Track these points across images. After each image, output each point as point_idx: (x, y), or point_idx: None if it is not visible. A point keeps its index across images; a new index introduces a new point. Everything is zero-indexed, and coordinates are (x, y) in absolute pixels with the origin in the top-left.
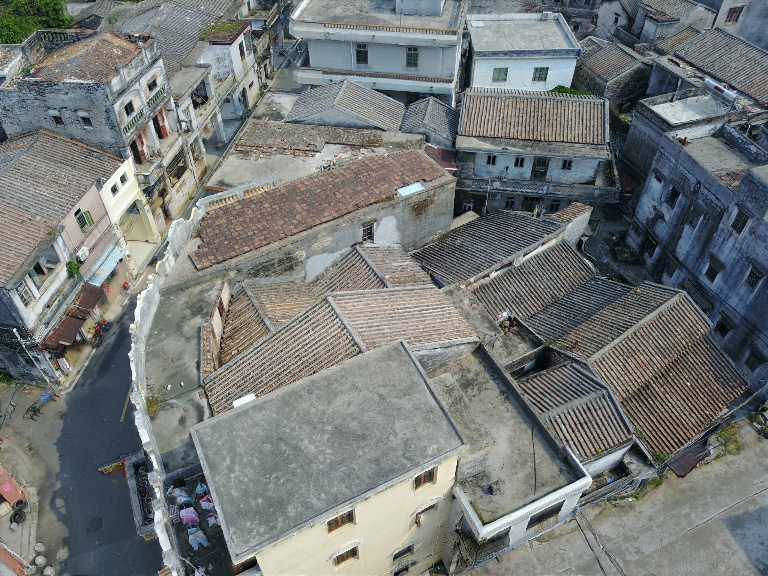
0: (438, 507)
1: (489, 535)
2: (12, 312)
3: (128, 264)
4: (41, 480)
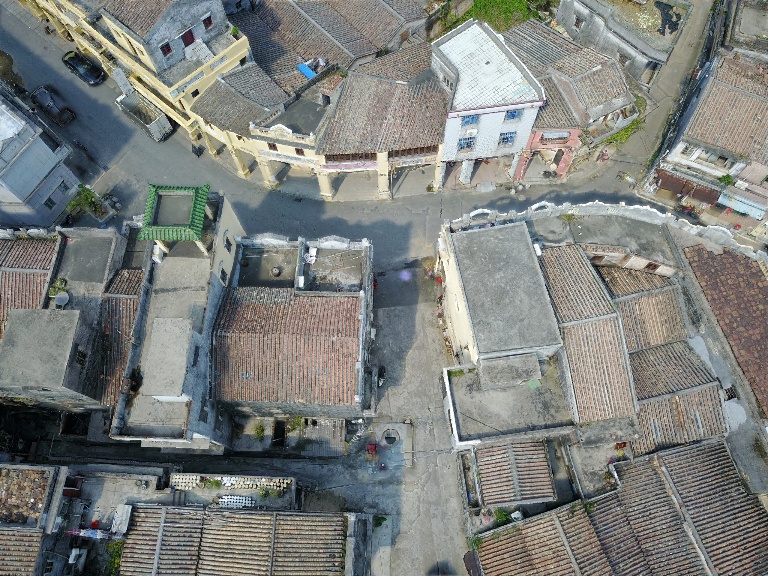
0: None
1: None
2: (674, 145)
3: (759, 226)
4: (571, 184)
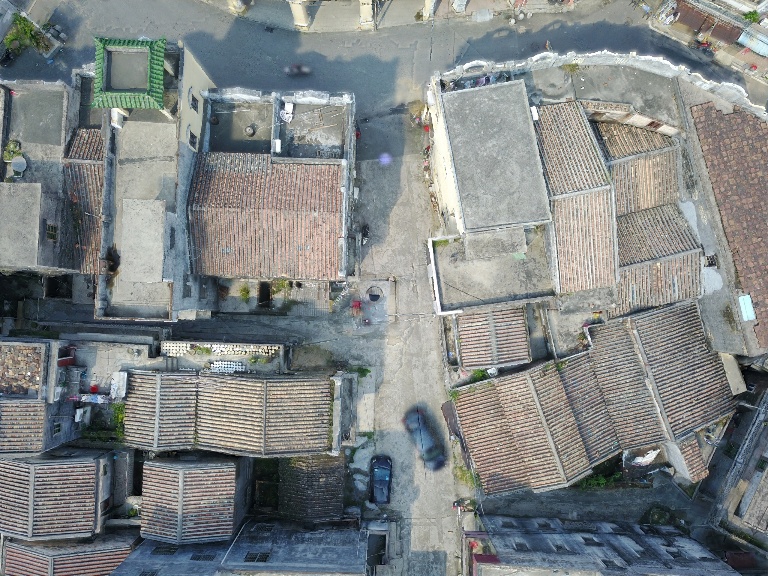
0: None
1: None
2: None
3: None
4: (578, 13)
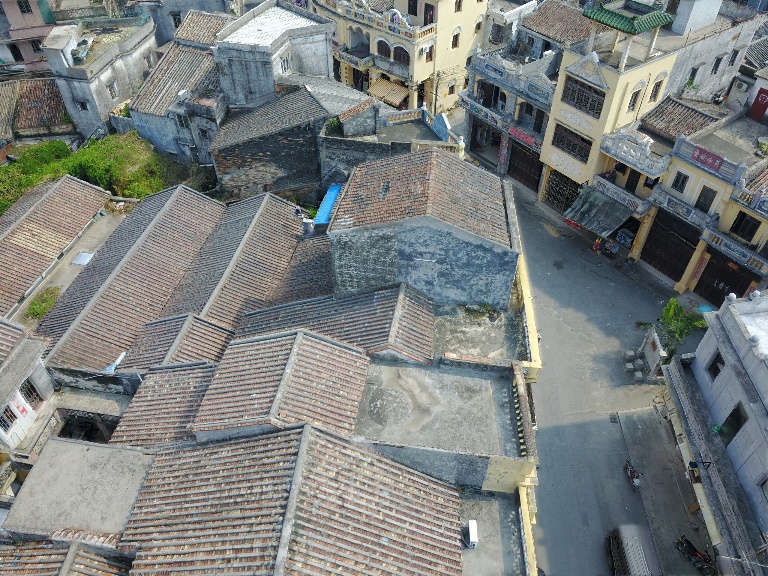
0: (481, 27)
1: (507, 20)
2: None
3: None
4: None
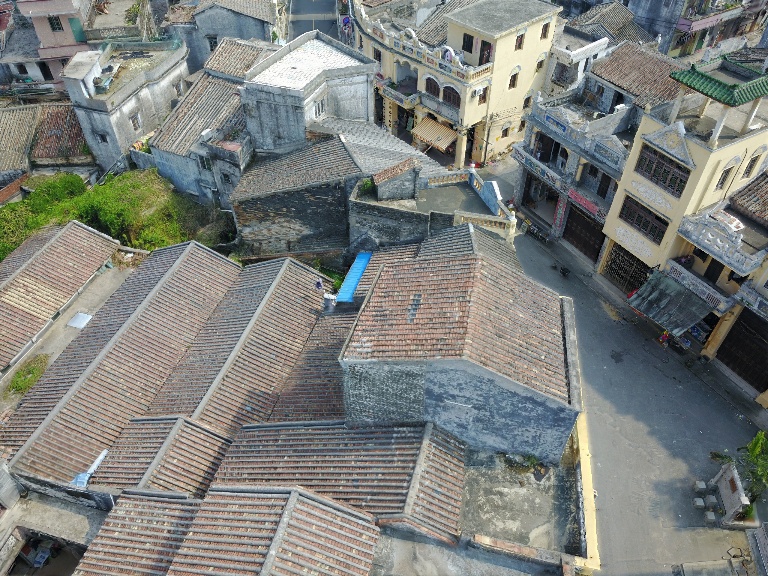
0: (544, 66)
1: (573, 60)
2: None
3: None
4: None
